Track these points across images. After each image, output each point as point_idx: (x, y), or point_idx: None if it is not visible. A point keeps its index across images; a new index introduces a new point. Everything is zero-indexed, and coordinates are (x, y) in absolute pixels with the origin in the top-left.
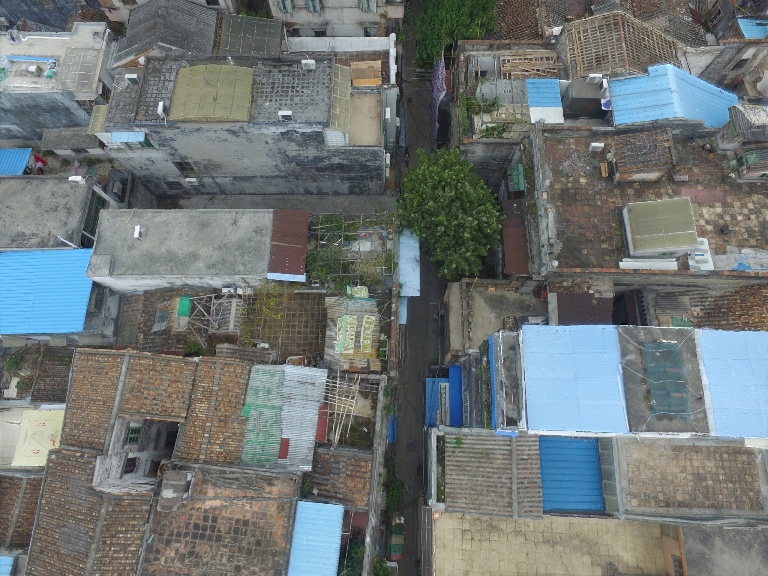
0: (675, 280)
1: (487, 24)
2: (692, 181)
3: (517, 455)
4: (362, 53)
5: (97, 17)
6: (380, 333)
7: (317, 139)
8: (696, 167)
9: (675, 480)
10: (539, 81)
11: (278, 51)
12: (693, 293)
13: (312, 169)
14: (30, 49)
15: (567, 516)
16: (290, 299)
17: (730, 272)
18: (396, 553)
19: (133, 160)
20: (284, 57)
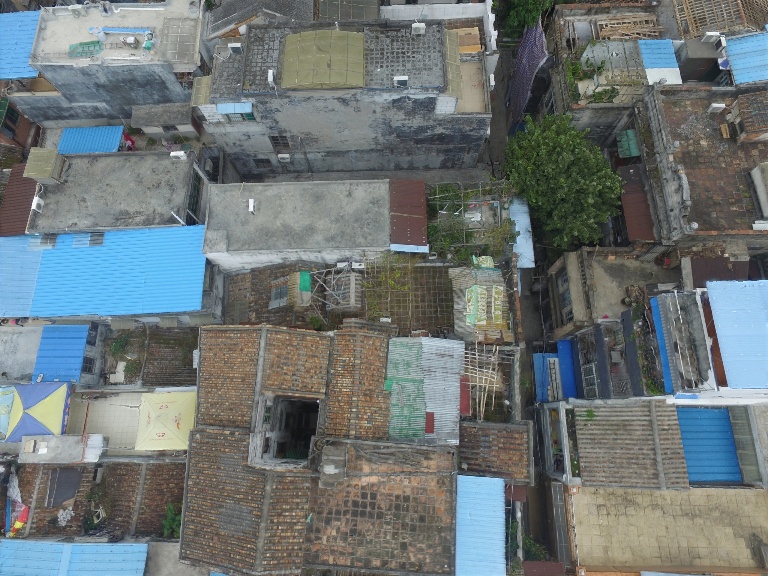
0: None
1: None
2: None
3: (658, 425)
4: (455, 21)
5: None
6: None
7: (428, 106)
8: None
9: None
10: (652, 42)
11: (377, 18)
12: None
13: (411, 141)
14: (123, 21)
15: (709, 487)
16: None
17: None
18: None
19: (229, 135)
20: (391, 22)
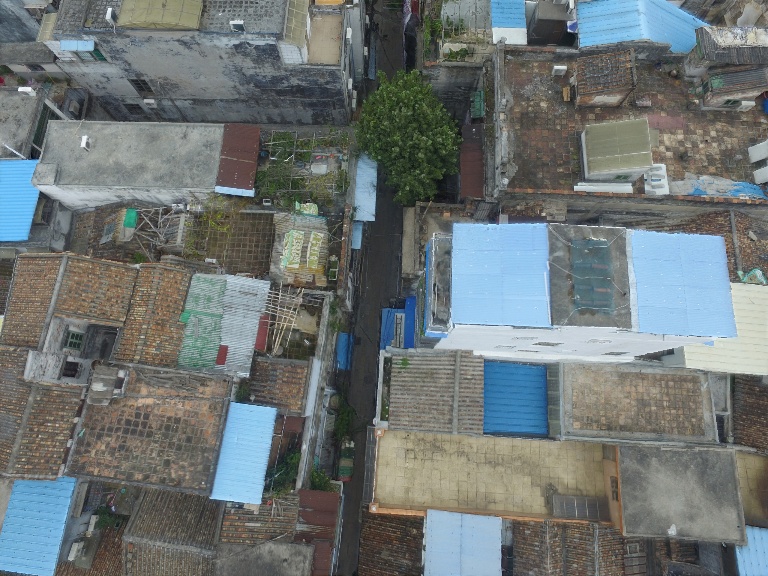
0: (630, 206)
1: None
2: (655, 108)
3: (460, 374)
4: None
5: None
6: None
7: (272, 54)
8: (661, 94)
9: (619, 405)
10: (504, 1)
11: None
12: (650, 223)
13: (272, 92)
14: None
15: (509, 437)
16: (242, 219)
17: (685, 196)
18: (344, 475)
19: (88, 76)
20: None
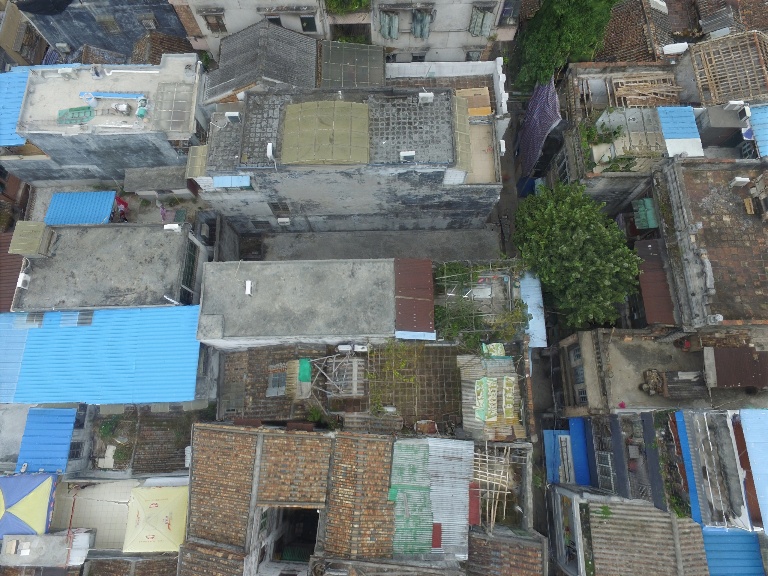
0: None
1: (594, 43)
2: None
3: (678, 529)
4: (463, 78)
5: (166, 42)
6: (519, 394)
7: (435, 179)
8: None
9: None
10: (671, 109)
11: (382, 80)
12: None
13: (417, 207)
14: (116, 85)
15: None
16: None
17: None
18: None
19: (226, 202)
20: (398, 89)
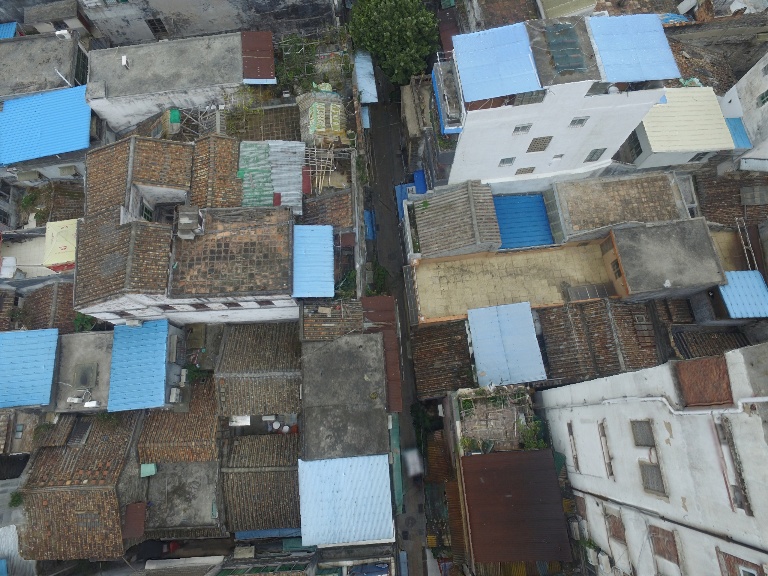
0: None
1: None
2: None
3: (474, 199)
4: None
5: None
6: None
7: None
8: None
9: (607, 207)
10: None
11: None
12: None
13: (270, 16)
14: None
15: (523, 247)
16: (266, 114)
17: None
18: None
19: (110, 22)
20: None
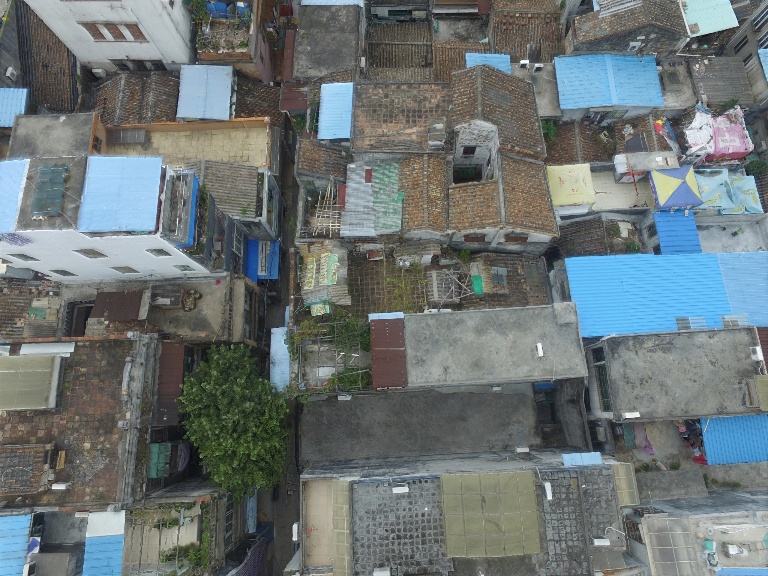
0: None
1: None
2: None
3: None
4: None
5: None
6: None
7: None
8: None
9: None
10: None
11: None
12: None
13: None
14: None
15: None
16: None
17: None
18: None
19: None
20: None
